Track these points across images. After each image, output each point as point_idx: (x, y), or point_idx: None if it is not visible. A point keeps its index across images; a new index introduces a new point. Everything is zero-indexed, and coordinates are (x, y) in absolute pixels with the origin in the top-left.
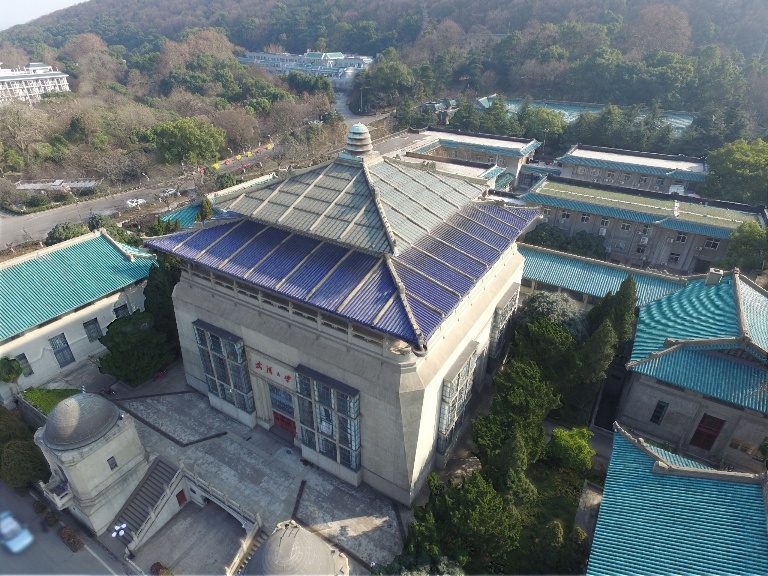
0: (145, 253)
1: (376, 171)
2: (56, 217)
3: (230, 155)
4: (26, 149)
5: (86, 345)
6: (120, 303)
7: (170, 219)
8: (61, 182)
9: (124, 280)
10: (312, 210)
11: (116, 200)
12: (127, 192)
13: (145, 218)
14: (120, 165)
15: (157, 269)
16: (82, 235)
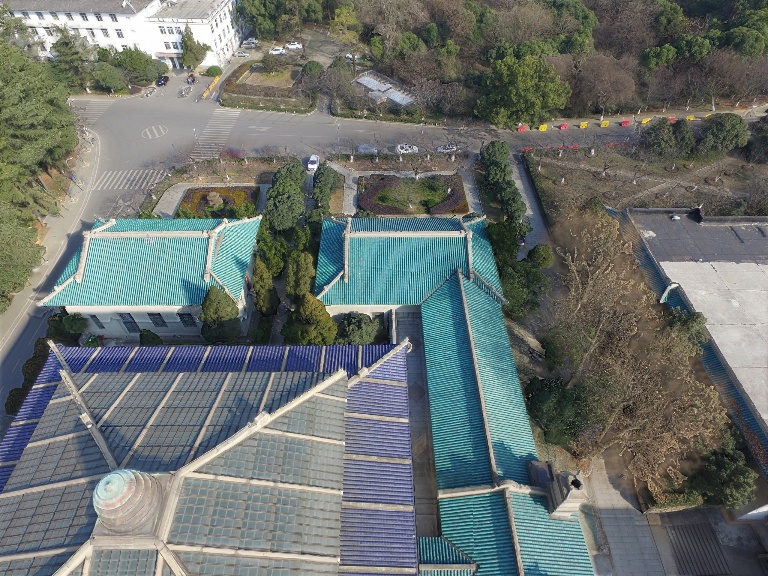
0: (240, 271)
1: (101, 568)
2: (345, 132)
3: (582, 114)
4: (389, 39)
5: (151, 327)
6: (184, 311)
7: (325, 228)
8: (388, 88)
9: (182, 299)
10: (8, 531)
11: (404, 133)
12: (426, 125)
13: (379, 181)
14: (428, 96)
15: (145, 336)
16: (192, 231)
